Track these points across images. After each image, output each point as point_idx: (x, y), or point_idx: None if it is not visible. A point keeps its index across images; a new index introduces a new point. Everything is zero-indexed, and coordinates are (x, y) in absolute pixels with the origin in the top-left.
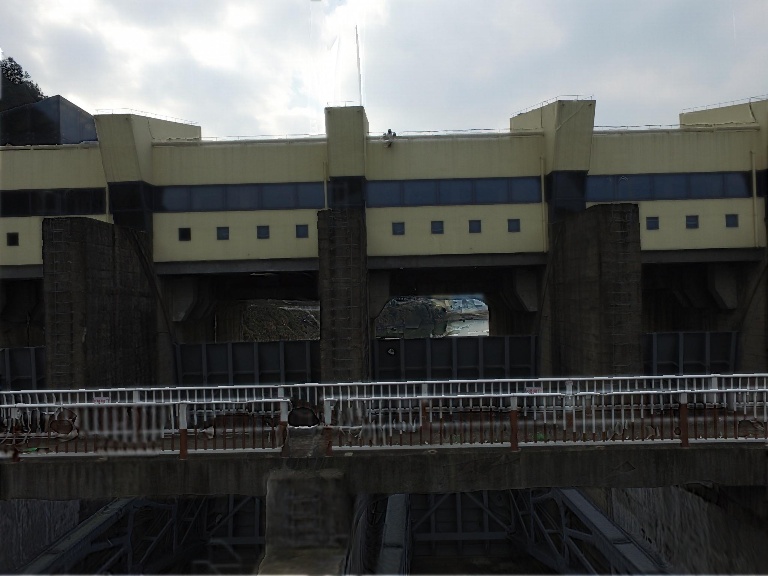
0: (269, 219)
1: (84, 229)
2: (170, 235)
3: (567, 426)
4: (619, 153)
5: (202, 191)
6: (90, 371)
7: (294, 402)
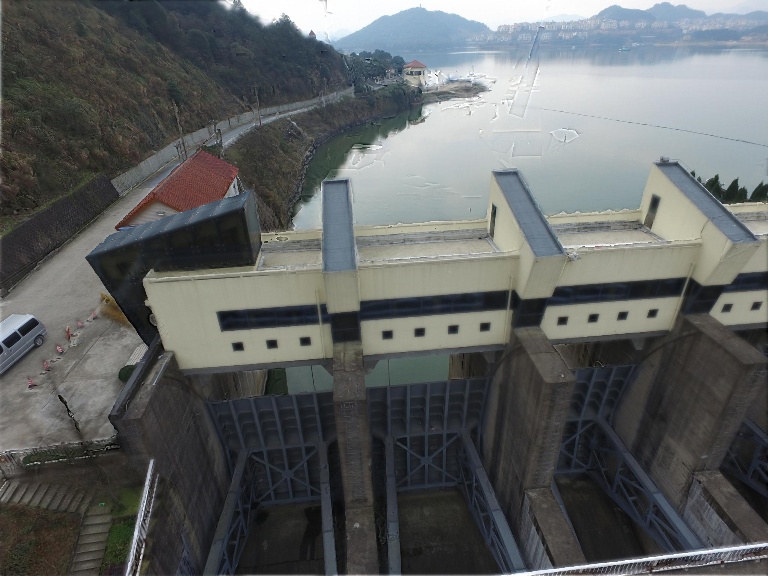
0: (459, 320)
1: None
2: (375, 336)
3: None
4: (755, 257)
5: (400, 300)
6: None
7: (586, 572)
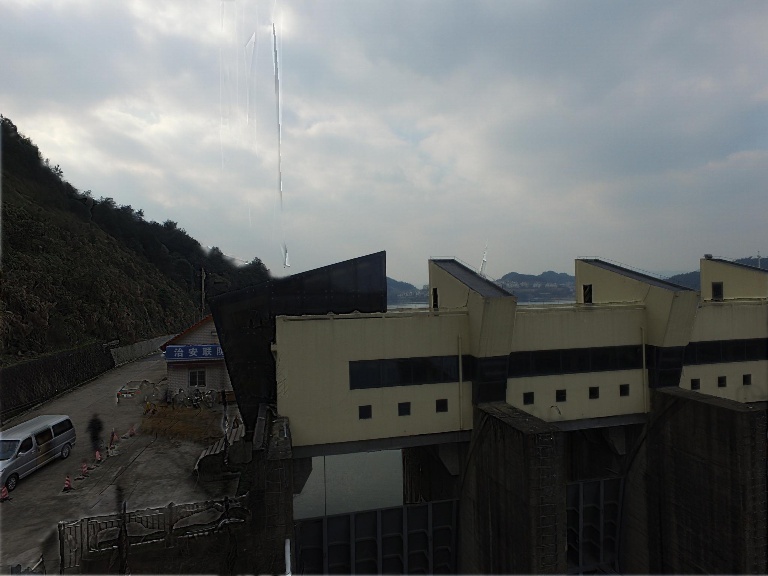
0: (598, 380)
1: None
2: (515, 400)
3: None
4: None
5: (539, 355)
6: None
7: None
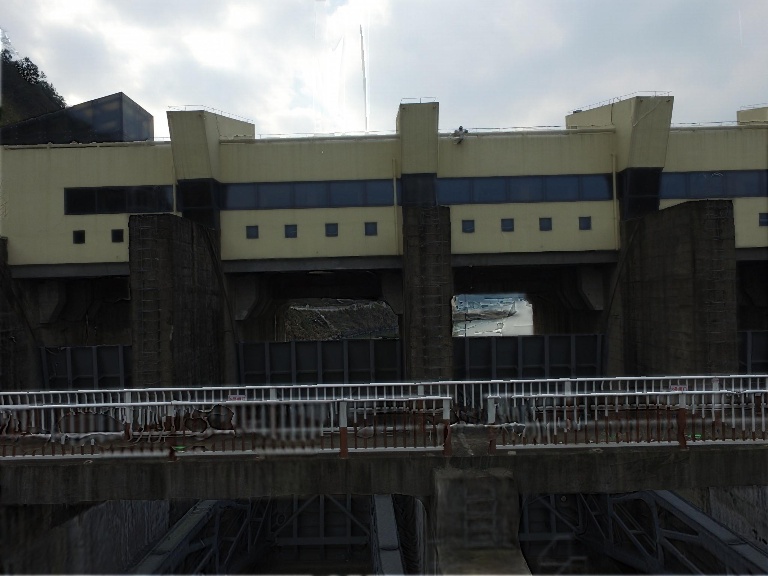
0: (337, 217)
1: (171, 226)
2: (238, 233)
3: (736, 424)
4: (691, 150)
5: (269, 188)
6: (176, 369)
7: None
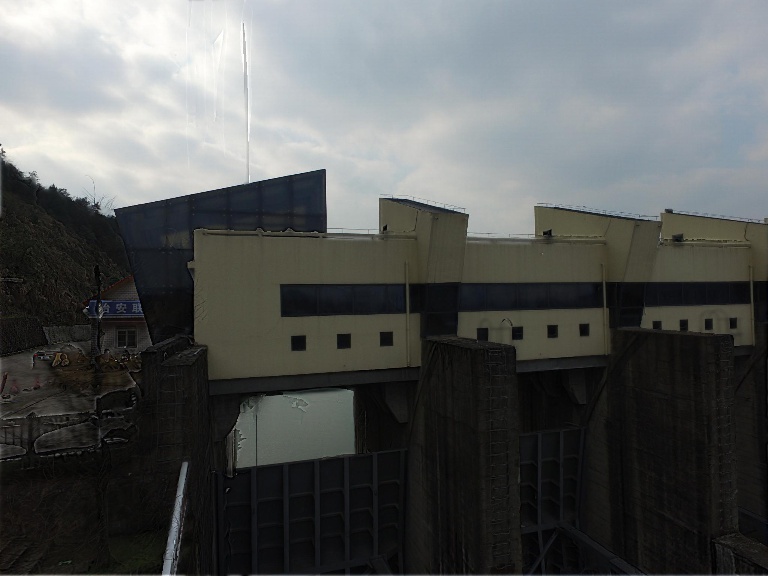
0: (557, 318)
1: None
2: (468, 336)
3: None
4: None
5: (494, 288)
6: None
7: None
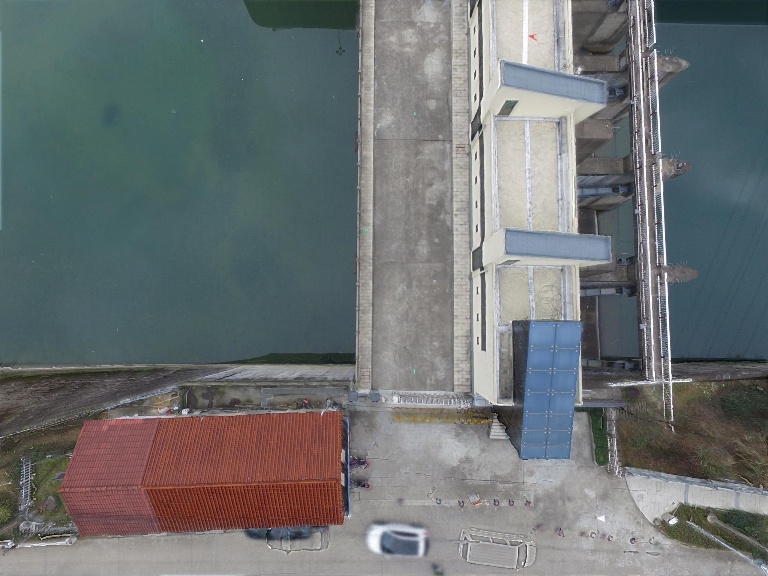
0: None
1: None
2: None
3: None
4: None
5: None
6: None
7: None
